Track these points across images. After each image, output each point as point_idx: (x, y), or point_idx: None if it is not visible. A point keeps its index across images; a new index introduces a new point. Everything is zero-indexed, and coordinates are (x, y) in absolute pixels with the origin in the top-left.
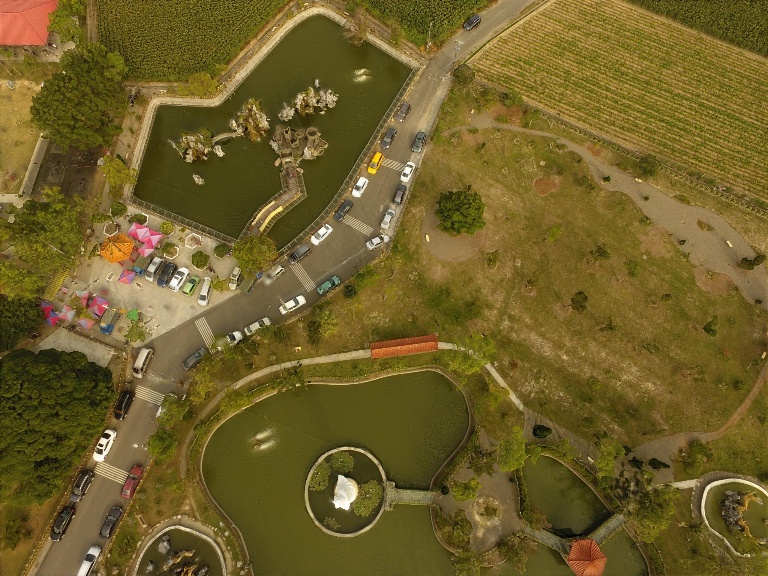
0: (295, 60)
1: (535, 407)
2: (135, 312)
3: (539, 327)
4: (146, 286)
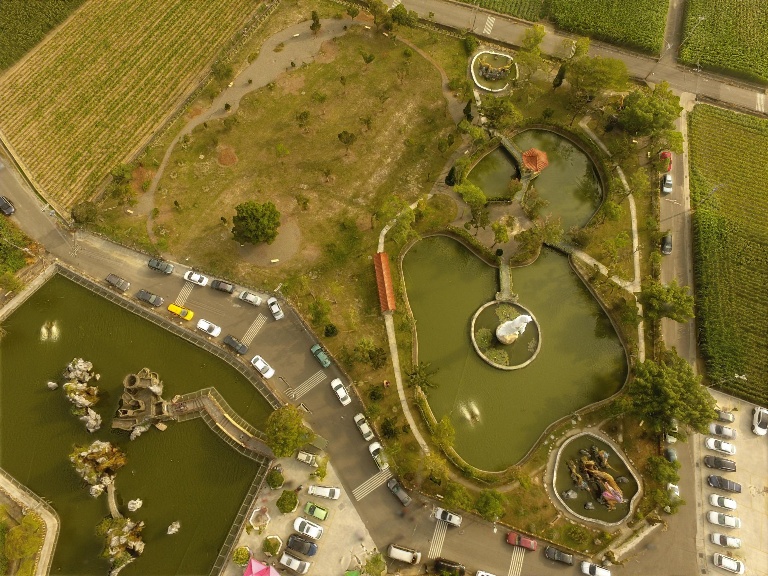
0: (5, 418)
1: (430, 185)
2: (349, 575)
3: (364, 176)
4: (314, 572)
